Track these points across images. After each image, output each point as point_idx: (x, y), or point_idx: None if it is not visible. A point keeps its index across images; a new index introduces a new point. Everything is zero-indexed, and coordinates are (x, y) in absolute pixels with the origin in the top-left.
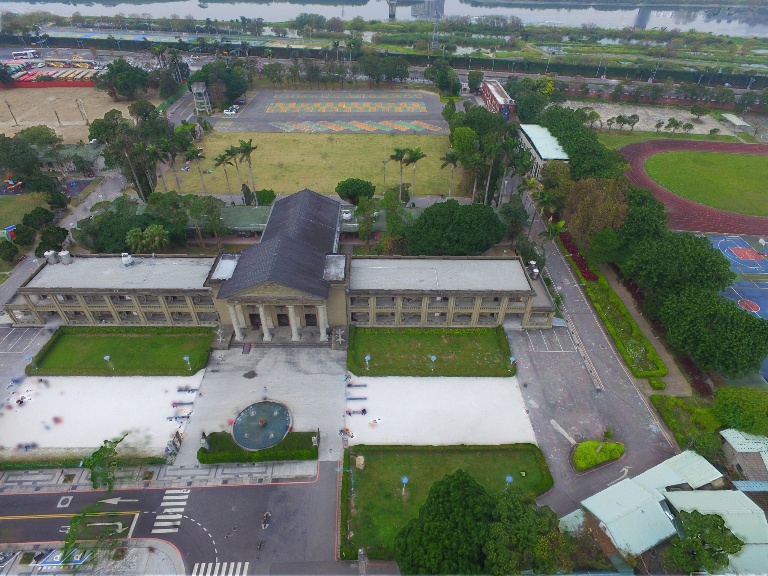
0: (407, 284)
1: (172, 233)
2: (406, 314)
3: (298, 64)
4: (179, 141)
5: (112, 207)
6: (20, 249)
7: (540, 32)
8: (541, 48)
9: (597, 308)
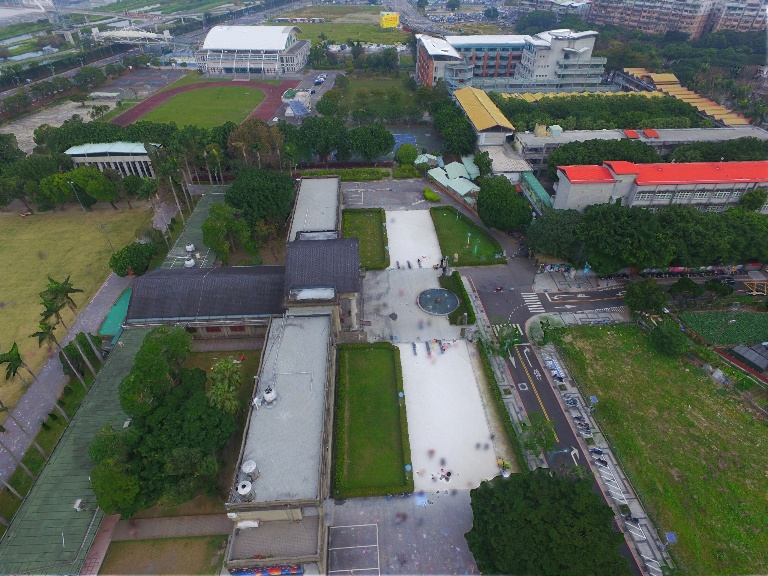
0: (326, 218)
1: None
2: None
3: None
4: None
5: None
6: None
7: None
8: None
9: None
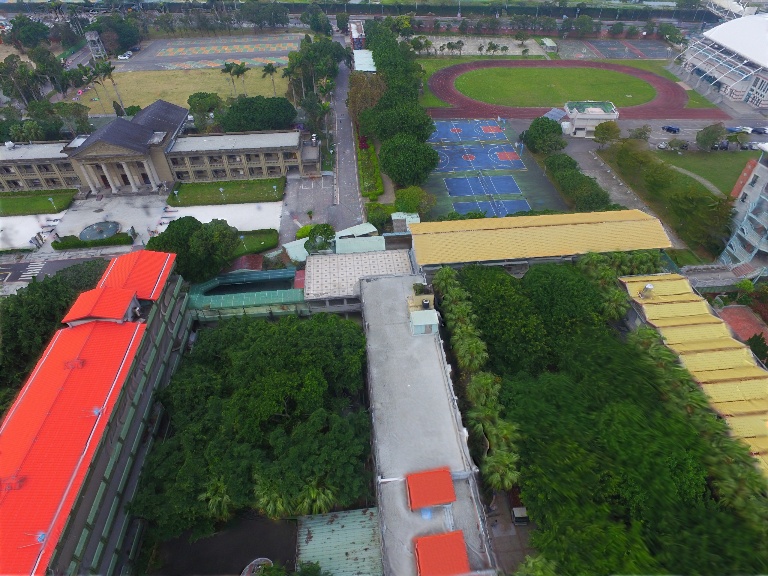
0: (211, 148)
1: (48, 130)
2: (217, 173)
3: None
4: None
5: (1, 115)
6: None
7: None
8: None
9: (358, 164)
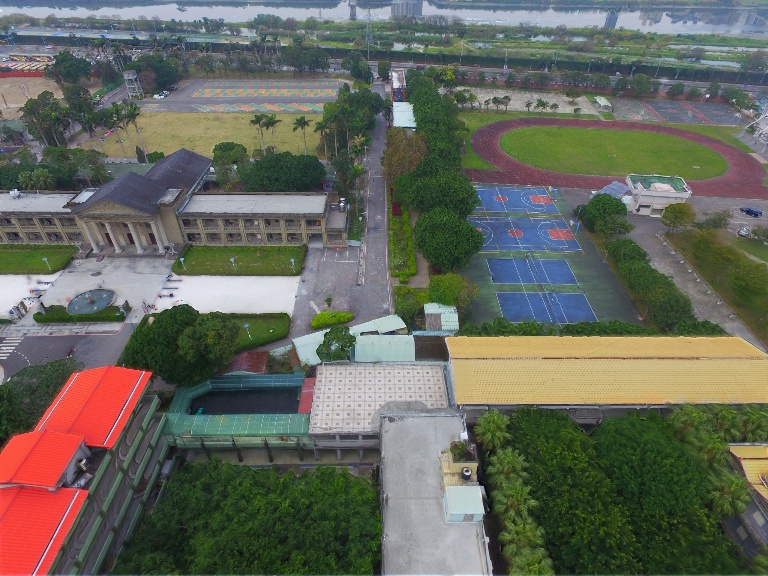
0: (228, 210)
1: (59, 178)
2: (232, 236)
3: (230, 56)
4: (99, 117)
5: (15, 158)
6: None
7: (479, 30)
8: (476, 44)
9: (390, 234)
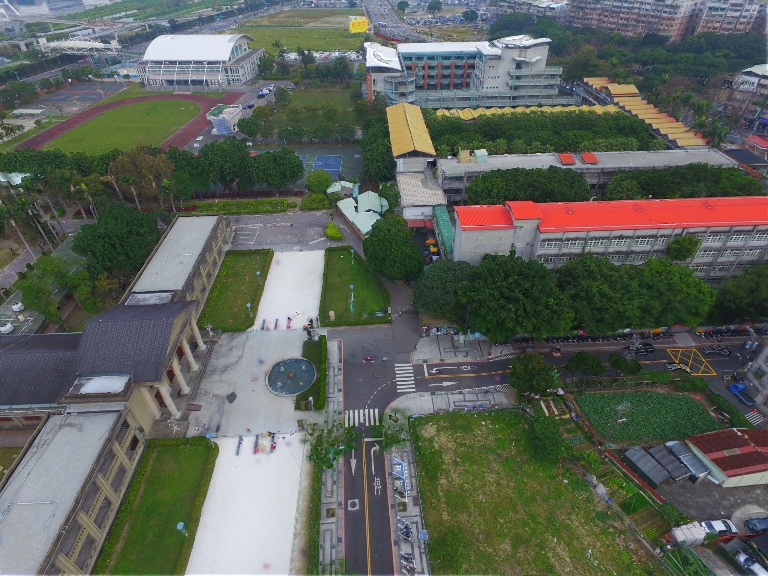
0: (182, 270)
1: None
2: None
3: None
4: None
5: None
6: None
7: None
8: None
9: (225, 212)
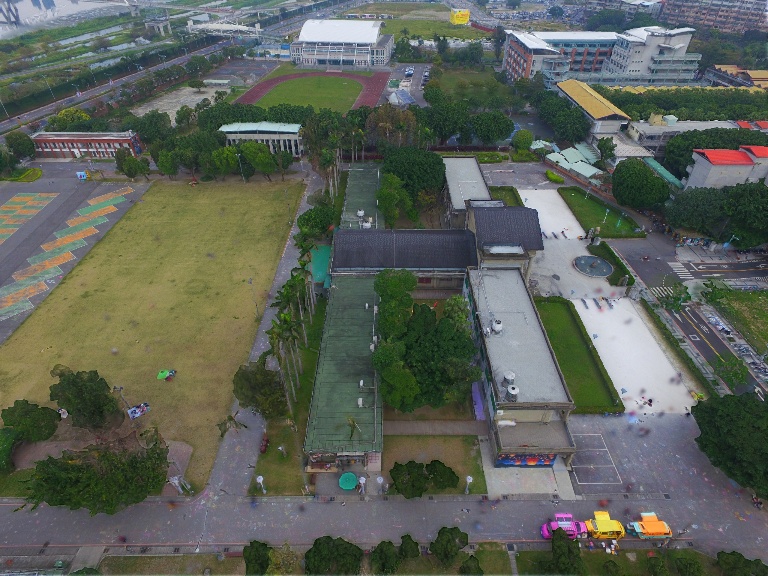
0: (479, 191)
1: None
2: None
3: None
4: (50, 413)
5: None
6: (405, 573)
7: None
8: None
9: None
